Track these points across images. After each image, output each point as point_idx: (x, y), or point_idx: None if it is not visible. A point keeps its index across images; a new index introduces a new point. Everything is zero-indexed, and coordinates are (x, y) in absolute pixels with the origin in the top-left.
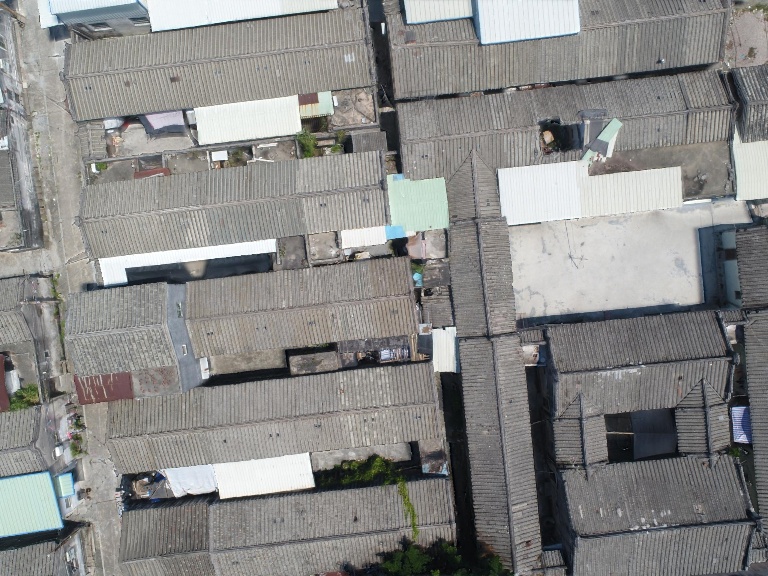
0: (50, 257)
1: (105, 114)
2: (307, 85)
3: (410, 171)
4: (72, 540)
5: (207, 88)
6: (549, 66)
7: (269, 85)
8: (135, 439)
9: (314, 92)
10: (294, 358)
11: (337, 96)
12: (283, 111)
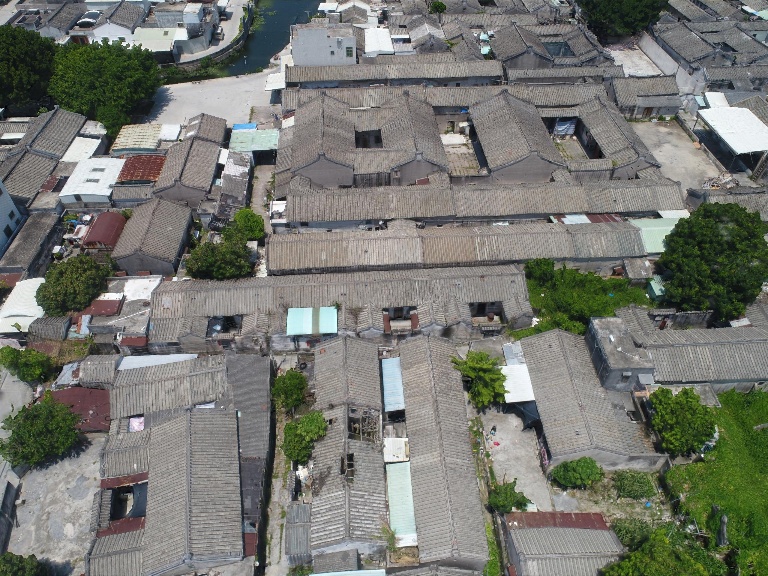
0: None
1: None
2: None
3: None
4: None
5: None
6: None
7: None
8: None
9: None
10: (696, 5)
11: None
12: None
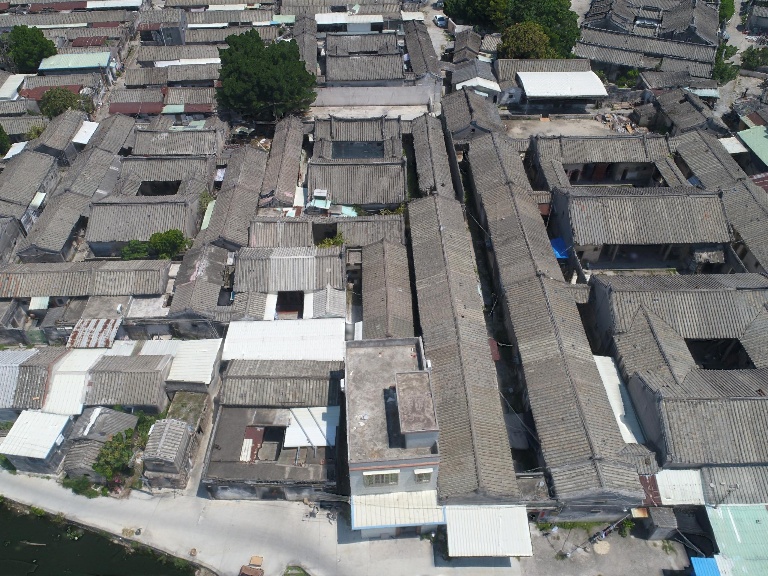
0: (135, 42)
1: (177, 4)
2: (251, 1)
3: (283, 14)
4: (103, 85)
5: (216, 0)
6: (337, 2)
7: (238, 1)
8: (152, 47)
9: (253, 3)
10: None
11: (261, 6)
12: (241, 6)
